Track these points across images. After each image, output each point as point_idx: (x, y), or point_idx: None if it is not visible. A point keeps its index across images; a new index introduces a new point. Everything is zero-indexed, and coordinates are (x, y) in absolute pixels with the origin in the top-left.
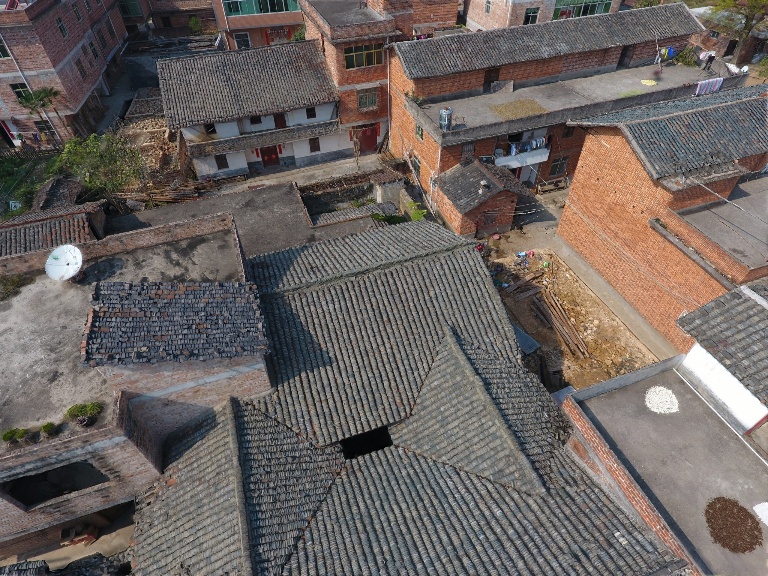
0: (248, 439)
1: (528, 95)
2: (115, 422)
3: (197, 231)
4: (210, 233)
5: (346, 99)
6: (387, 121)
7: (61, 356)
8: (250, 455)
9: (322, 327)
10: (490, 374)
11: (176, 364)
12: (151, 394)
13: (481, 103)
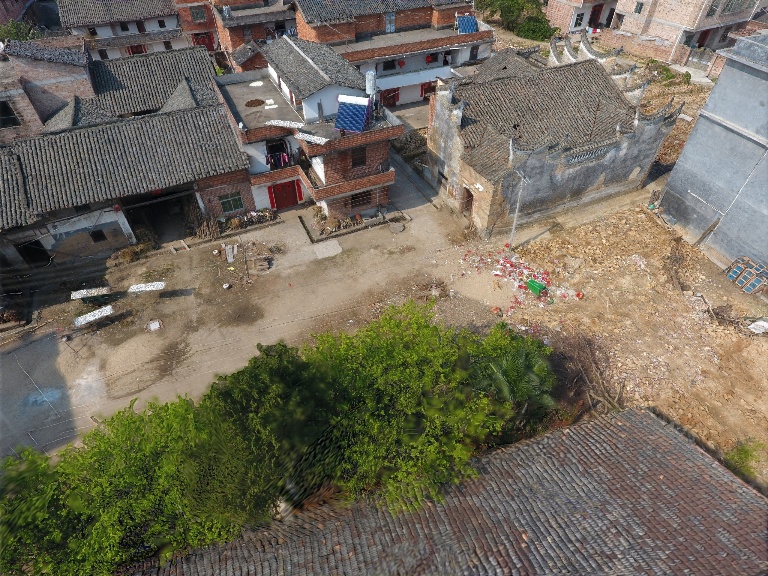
0: (81, 106)
1: None
2: (18, 80)
3: (65, 44)
4: (72, 46)
5: (183, 14)
6: (216, 31)
7: None
8: (81, 109)
9: (123, 76)
10: (198, 90)
11: (44, 65)
12: (35, 82)
13: (260, 10)
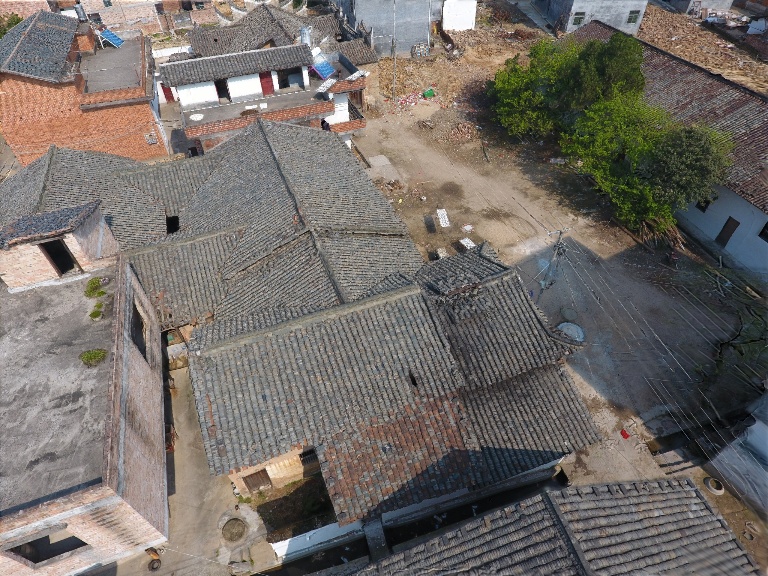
0: None
1: None
2: (118, 252)
3: None
4: None
5: None
6: None
7: (17, 324)
8: None
9: None
10: None
11: (87, 227)
12: None
13: None
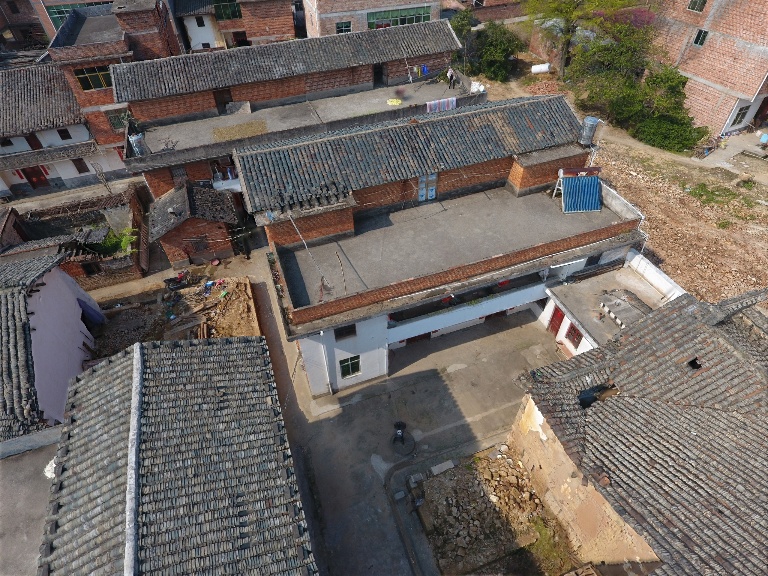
0: None
1: (263, 116)
2: None
3: None
4: None
5: (95, 120)
6: None
7: None
8: None
9: None
10: None
11: None
12: None
13: (209, 125)
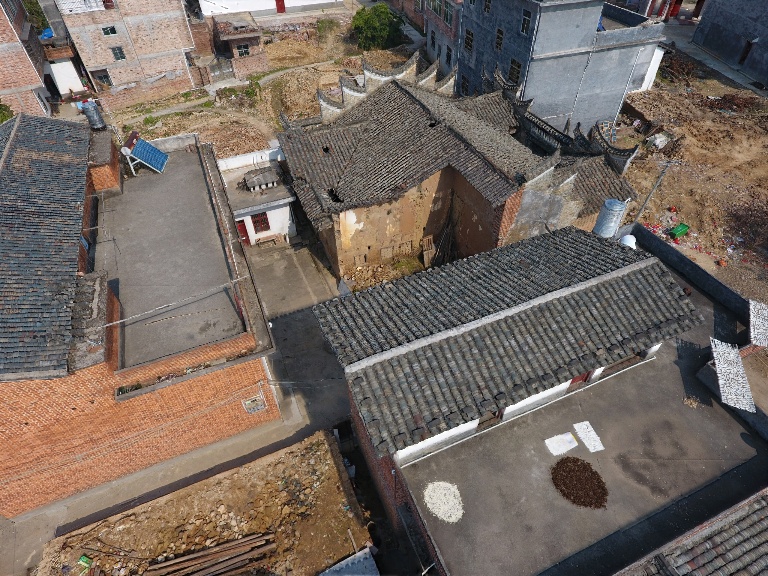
0: None
1: None
2: None
3: None
4: None
5: None
6: None
7: None
8: None
9: None
10: None
11: None
12: None
13: None
